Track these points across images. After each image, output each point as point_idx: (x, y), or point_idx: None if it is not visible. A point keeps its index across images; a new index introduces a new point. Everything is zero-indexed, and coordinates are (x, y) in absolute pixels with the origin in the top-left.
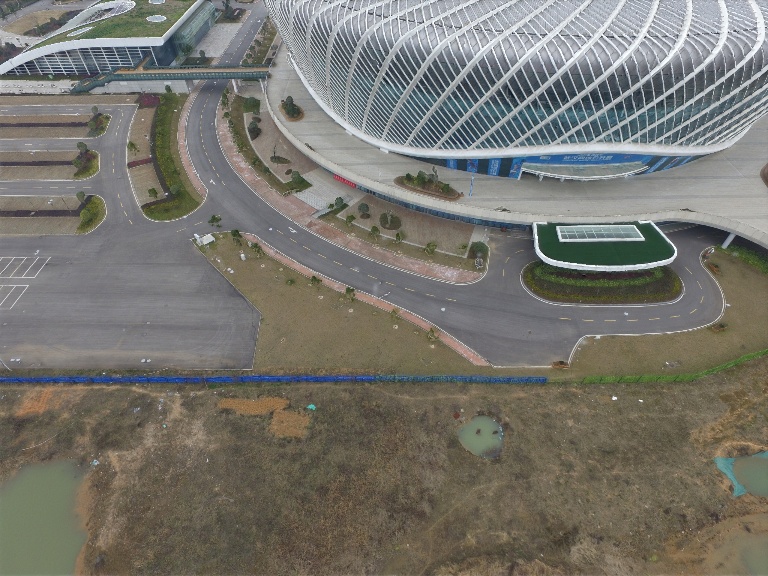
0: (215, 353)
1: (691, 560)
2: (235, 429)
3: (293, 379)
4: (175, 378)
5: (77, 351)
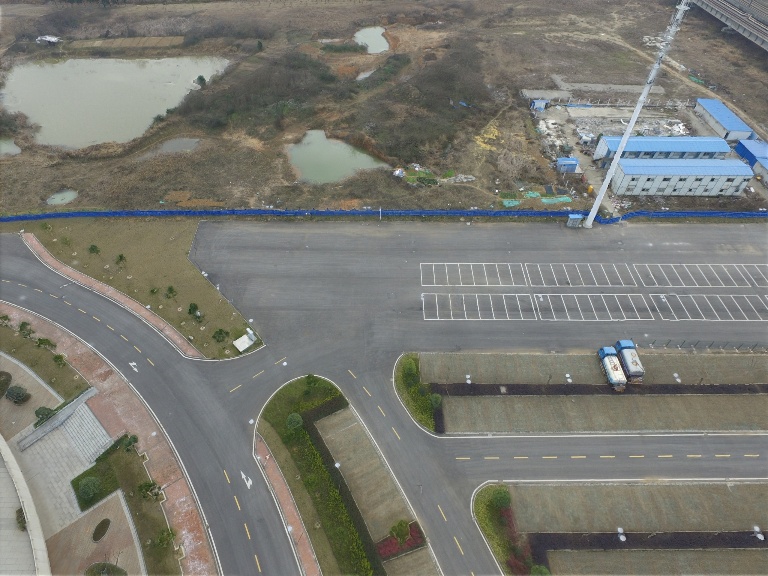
0: (228, 230)
1: (3, 161)
2: (213, 192)
3: (169, 212)
4: (253, 210)
5: (338, 232)
